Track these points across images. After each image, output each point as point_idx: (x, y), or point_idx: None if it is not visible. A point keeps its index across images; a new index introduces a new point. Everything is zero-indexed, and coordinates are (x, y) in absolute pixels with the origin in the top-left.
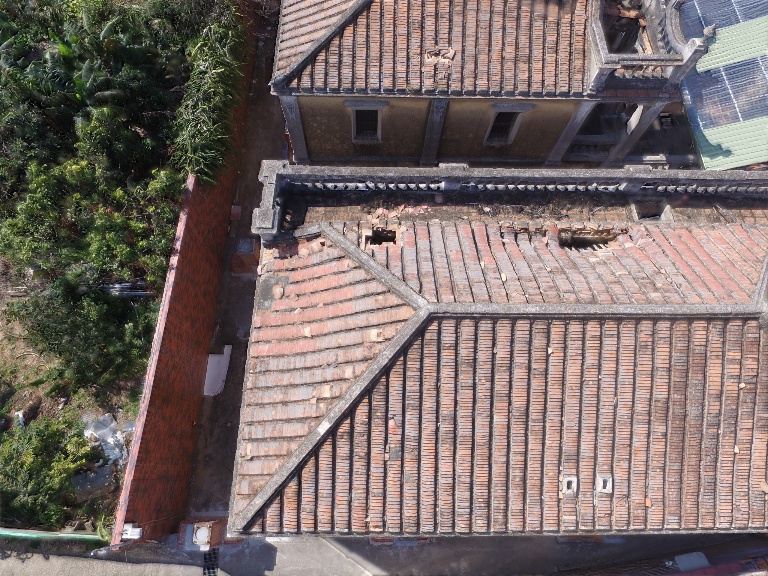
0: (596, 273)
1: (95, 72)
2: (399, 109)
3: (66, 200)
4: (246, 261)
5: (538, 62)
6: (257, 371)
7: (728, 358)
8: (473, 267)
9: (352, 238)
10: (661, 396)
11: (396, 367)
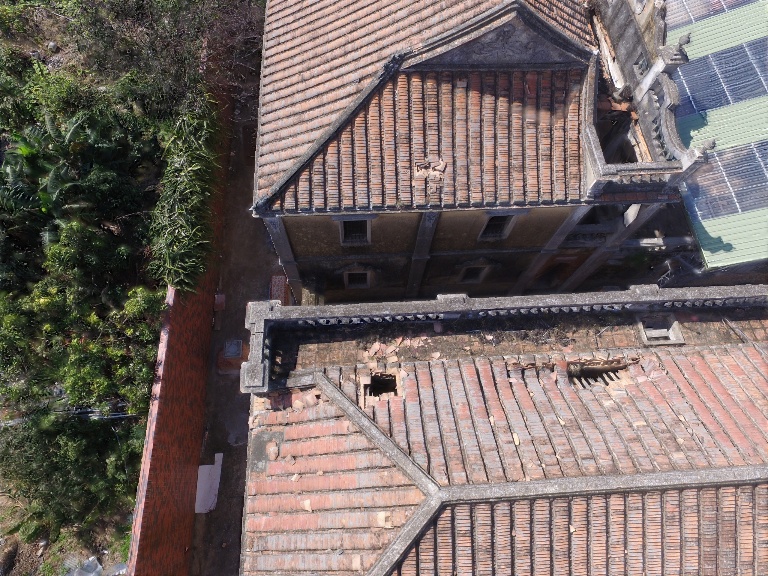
0: (613, 426)
1: (62, 179)
2: (389, 218)
3: (35, 328)
4: (233, 362)
5: (533, 170)
6: (254, 551)
7: (759, 522)
8: (483, 427)
9: (350, 391)
10: (691, 568)
11: (408, 559)
